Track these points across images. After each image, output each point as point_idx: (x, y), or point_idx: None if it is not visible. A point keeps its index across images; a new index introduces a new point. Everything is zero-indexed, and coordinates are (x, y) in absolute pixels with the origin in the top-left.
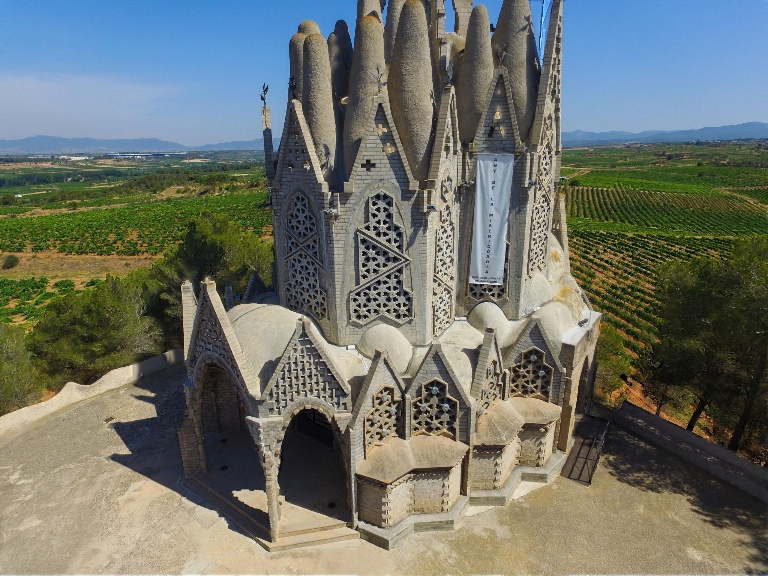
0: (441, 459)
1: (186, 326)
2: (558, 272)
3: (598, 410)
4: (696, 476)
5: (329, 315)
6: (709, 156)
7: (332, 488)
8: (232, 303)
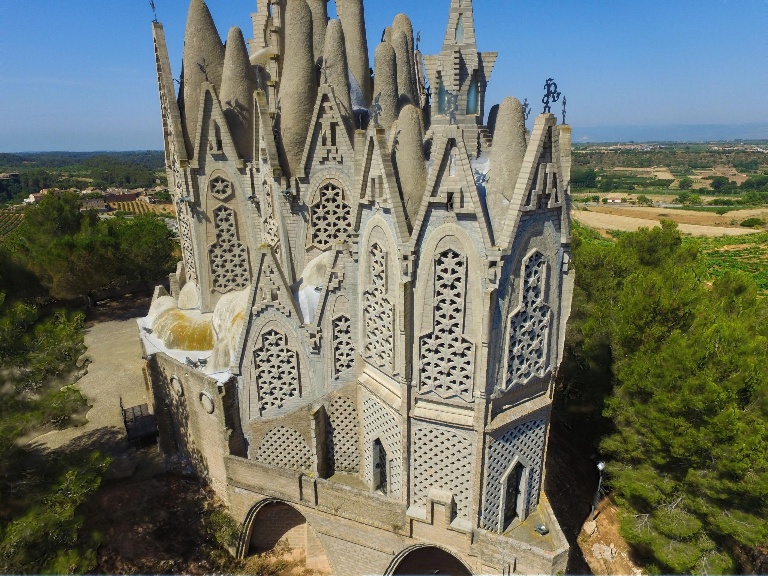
0: None
1: None
2: None
3: (159, 467)
4: None
5: None
6: None
7: None
8: None
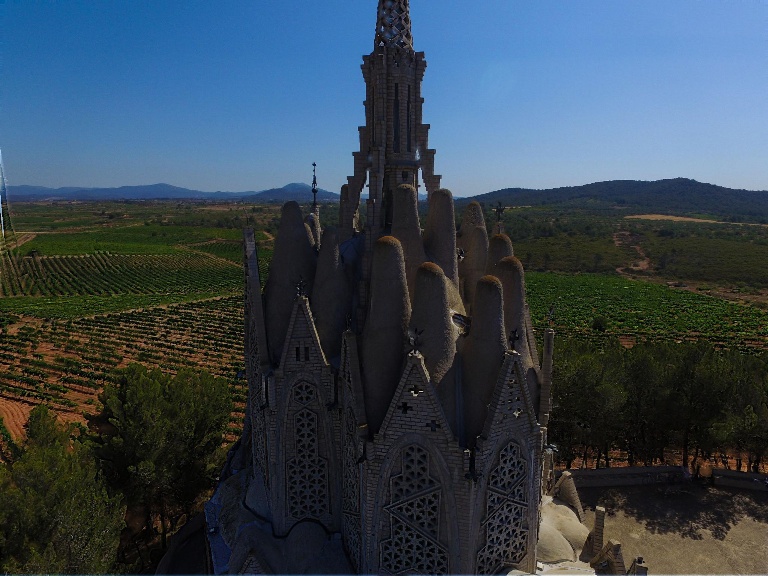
0: None
1: None
2: None
3: None
4: None
5: (528, 550)
6: (180, 223)
7: None
8: None
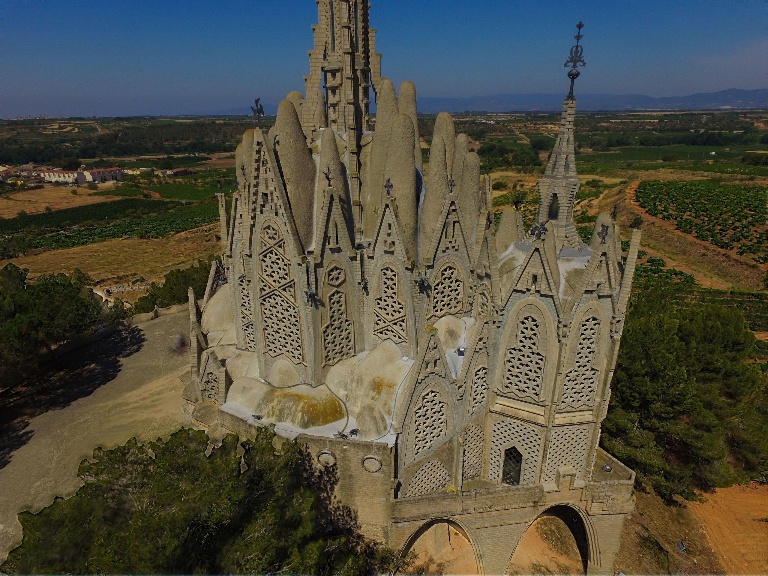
0: (186, 391)
1: None
2: (367, 400)
3: None
4: None
5: None
6: None
7: None
8: None
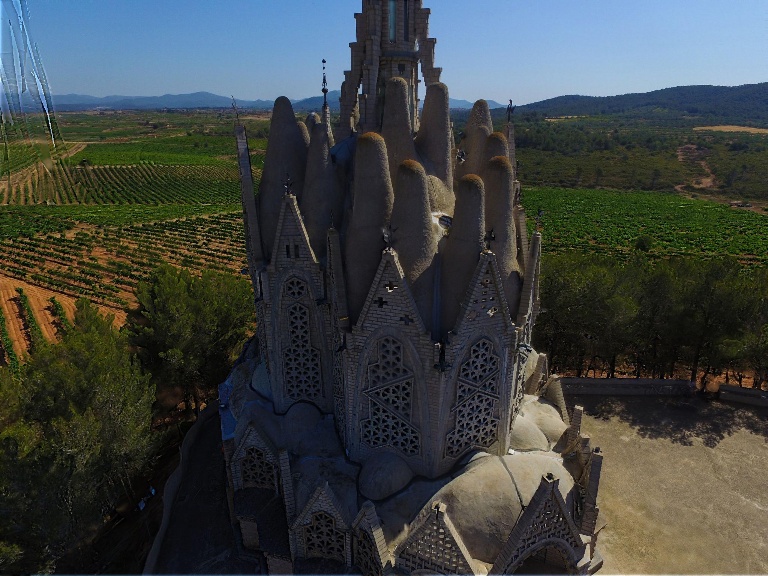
0: None
1: (463, 550)
2: None
3: None
4: (570, 400)
5: (498, 437)
6: (219, 133)
7: (538, 572)
8: (337, 500)
